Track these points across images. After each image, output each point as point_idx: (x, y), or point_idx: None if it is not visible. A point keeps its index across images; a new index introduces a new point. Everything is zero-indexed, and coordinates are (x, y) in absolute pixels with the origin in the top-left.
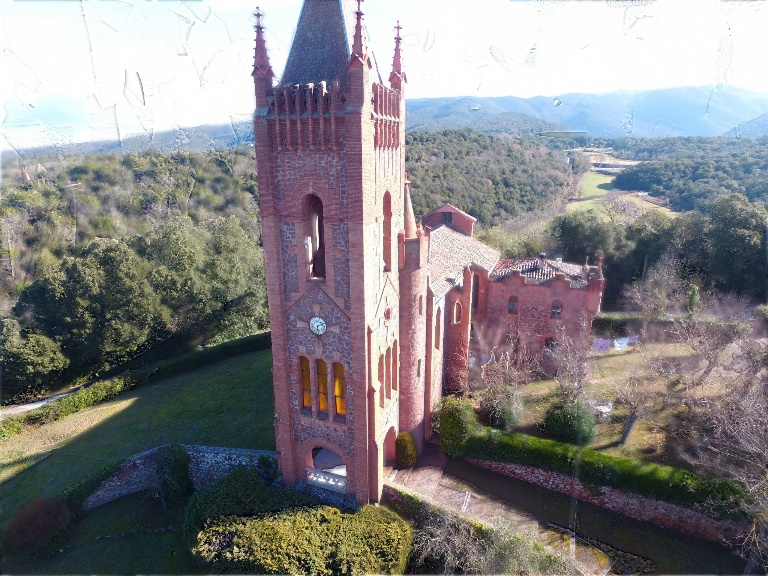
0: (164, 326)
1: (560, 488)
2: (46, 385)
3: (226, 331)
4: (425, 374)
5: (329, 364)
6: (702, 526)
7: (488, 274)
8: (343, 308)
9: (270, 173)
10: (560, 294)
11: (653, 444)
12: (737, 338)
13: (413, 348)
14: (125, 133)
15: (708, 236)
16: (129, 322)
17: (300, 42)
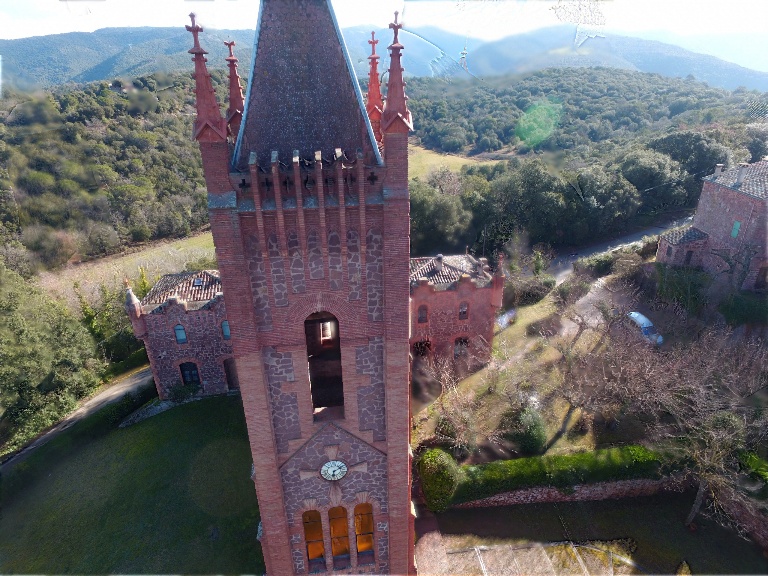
0: None
1: (538, 499)
2: None
3: (29, 422)
4: None
5: (351, 508)
6: (646, 487)
7: None
8: (372, 442)
9: (249, 293)
10: (466, 295)
11: (585, 424)
12: (582, 295)
13: None
14: None
15: (523, 199)
16: None
17: (266, 75)
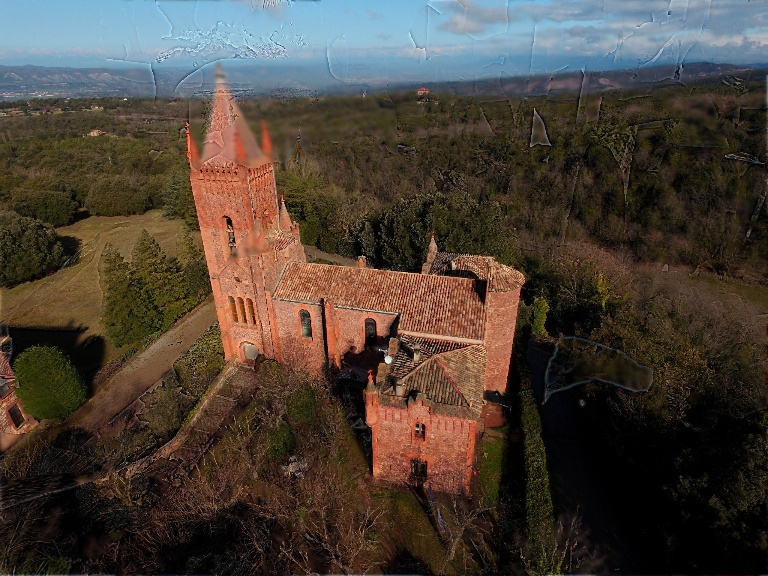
0: None
1: None
2: (374, 262)
3: None
4: None
5: None
6: None
7: (398, 331)
8: None
9: None
10: None
11: None
12: None
13: None
14: None
15: None
16: None
17: None
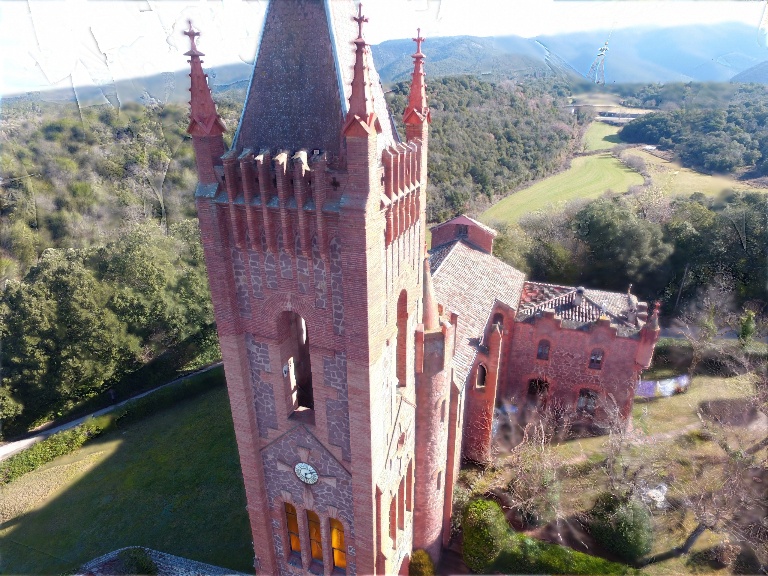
0: (134, 355)
1: None
2: None
3: (208, 351)
4: (445, 479)
5: (323, 518)
6: None
7: (514, 313)
8: (341, 459)
9: (226, 279)
10: (602, 341)
11: (724, 556)
12: None
13: (432, 461)
14: (86, 105)
15: (758, 239)
16: (91, 355)
17: (264, 75)
